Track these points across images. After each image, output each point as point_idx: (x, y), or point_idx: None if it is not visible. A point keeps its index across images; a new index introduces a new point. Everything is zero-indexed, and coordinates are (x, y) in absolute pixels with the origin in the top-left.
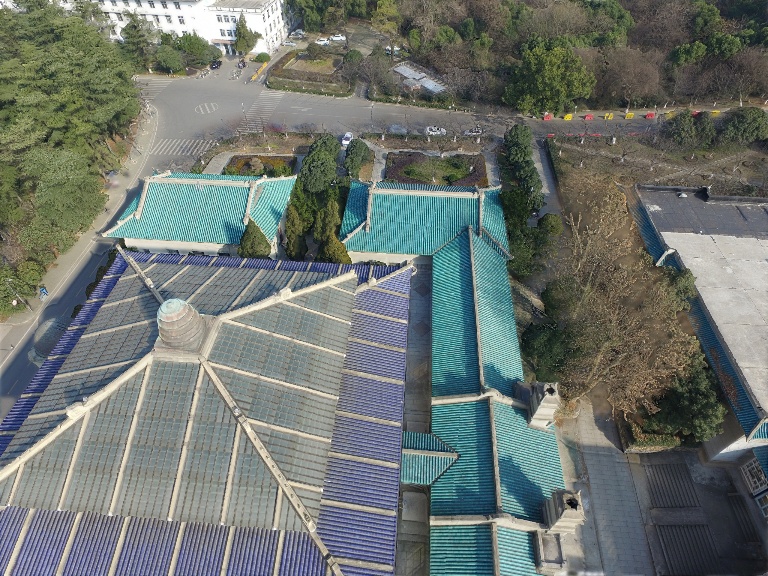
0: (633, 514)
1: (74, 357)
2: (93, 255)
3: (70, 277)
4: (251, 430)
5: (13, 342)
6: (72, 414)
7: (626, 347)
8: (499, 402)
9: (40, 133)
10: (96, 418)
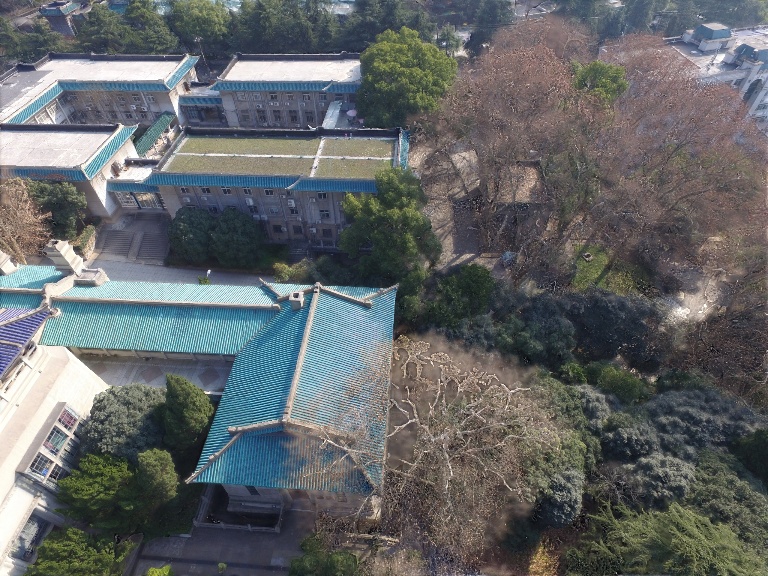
0: (126, 266)
1: None
2: None
3: None
4: None
5: None
6: None
7: (5, 225)
8: None
9: None
10: None
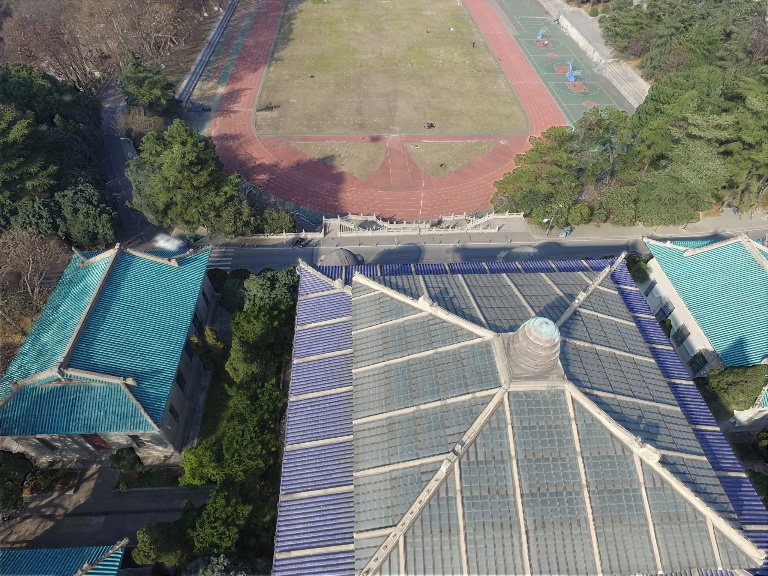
0: None
1: (482, 278)
2: (626, 245)
3: (593, 241)
4: (445, 472)
5: (515, 239)
6: (421, 302)
7: None
8: None
9: (724, 134)
10: (425, 321)
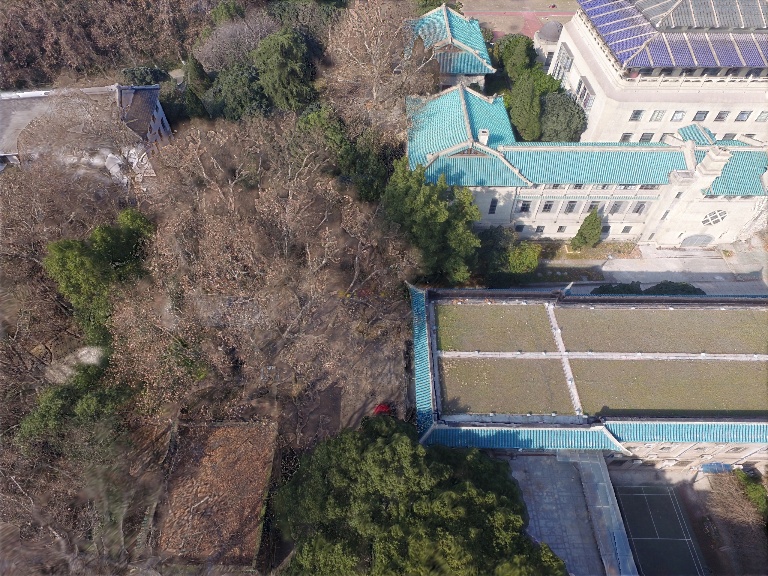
0: None
1: None
2: None
3: None
4: None
5: None
6: None
7: None
8: (767, 156)
9: None
10: None
